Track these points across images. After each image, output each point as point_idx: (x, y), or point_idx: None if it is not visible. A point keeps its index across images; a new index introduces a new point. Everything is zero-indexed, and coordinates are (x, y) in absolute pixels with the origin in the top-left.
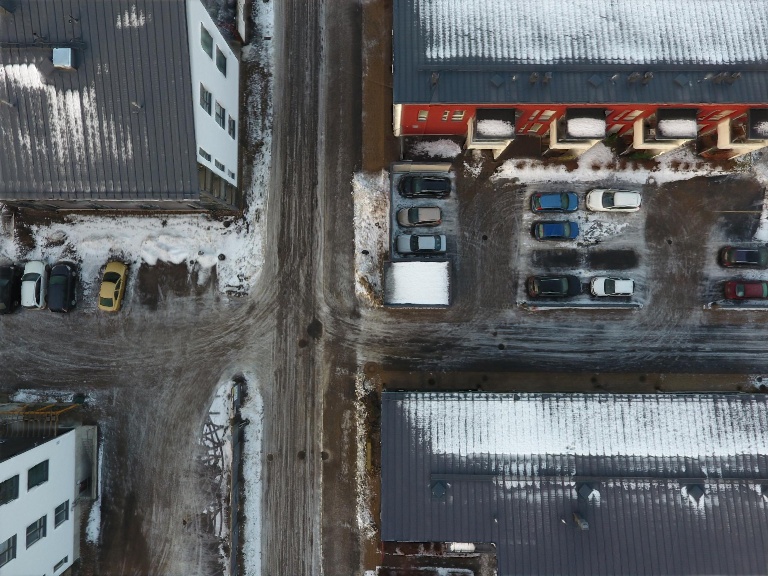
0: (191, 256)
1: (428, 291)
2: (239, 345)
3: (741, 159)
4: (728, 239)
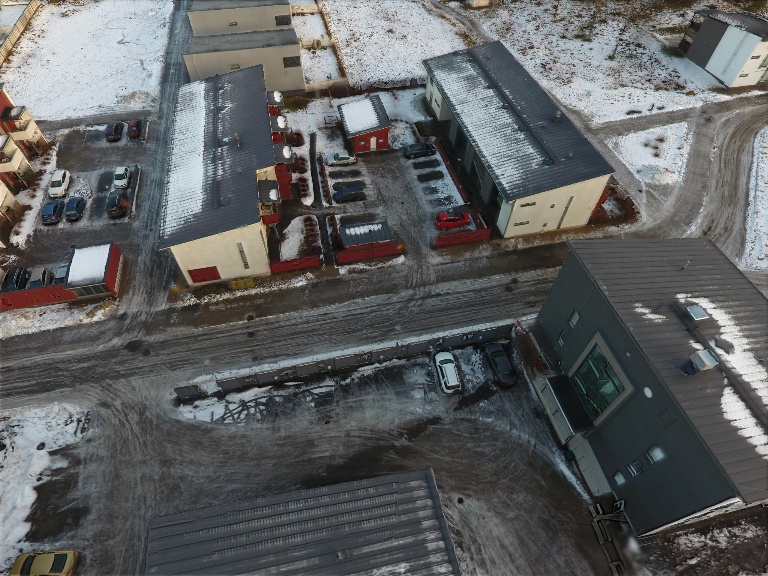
0: (31, 482)
1: (97, 257)
2: (142, 409)
3: (50, 140)
4: (102, 140)
